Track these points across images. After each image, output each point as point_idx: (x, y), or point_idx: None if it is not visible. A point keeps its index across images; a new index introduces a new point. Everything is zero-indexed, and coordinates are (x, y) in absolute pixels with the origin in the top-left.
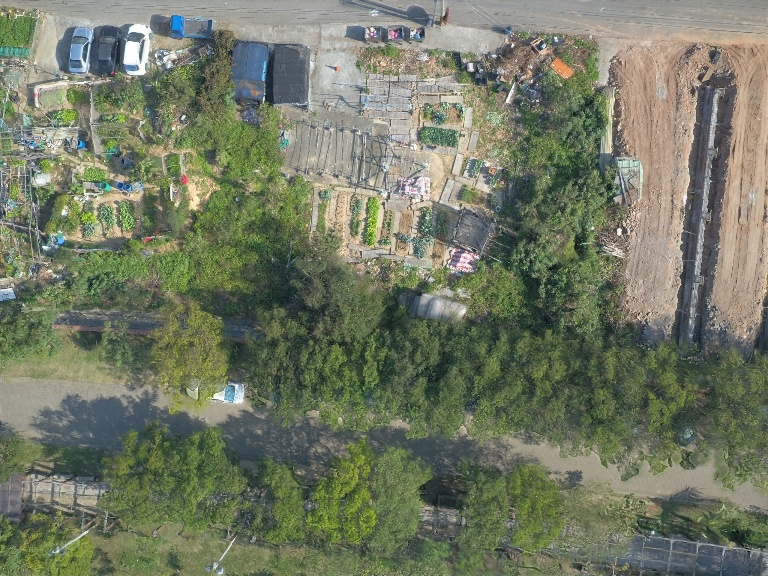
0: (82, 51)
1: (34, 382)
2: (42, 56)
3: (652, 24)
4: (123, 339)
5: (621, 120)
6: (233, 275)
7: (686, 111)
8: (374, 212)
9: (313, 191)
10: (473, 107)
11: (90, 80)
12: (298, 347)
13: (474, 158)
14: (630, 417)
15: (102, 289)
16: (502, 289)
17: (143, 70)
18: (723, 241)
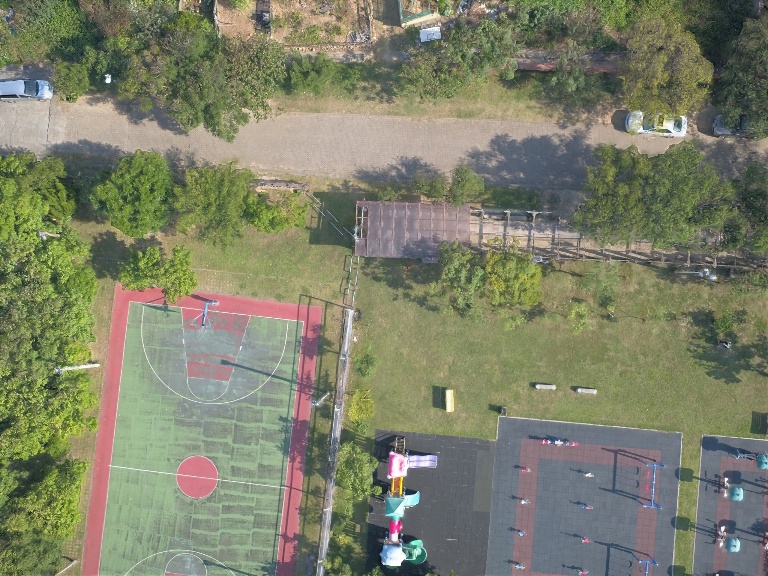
0: None
1: (461, 122)
2: None
3: None
4: None
5: None
6: (676, 6)
7: None
8: None
9: None
10: None
11: None
12: None
13: None
14: None
15: (547, 18)
16: None
17: None
18: None
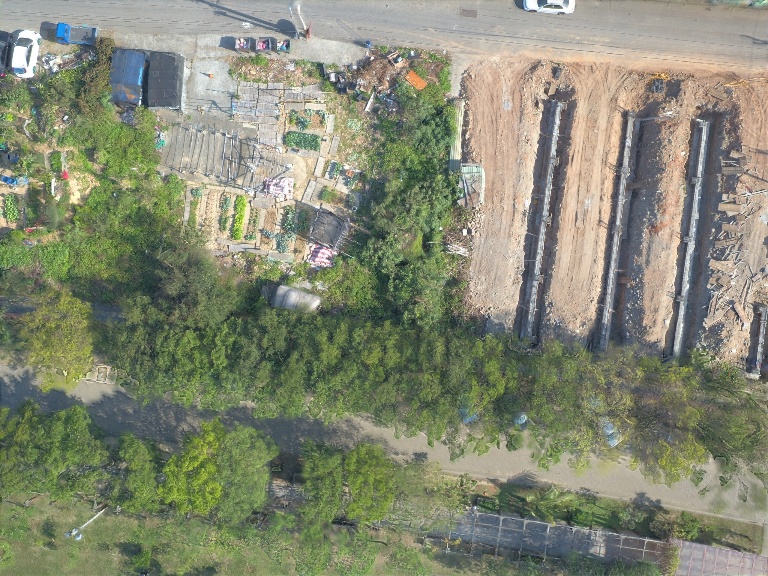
0: None
1: None
2: None
3: (501, 41)
4: (2, 322)
5: (469, 129)
6: (109, 265)
7: (529, 122)
8: (241, 209)
9: (186, 189)
10: (335, 114)
11: None
12: (155, 331)
13: (335, 161)
14: (455, 401)
15: None
16: (356, 283)
17: (31, 73)
18: (561, 243)
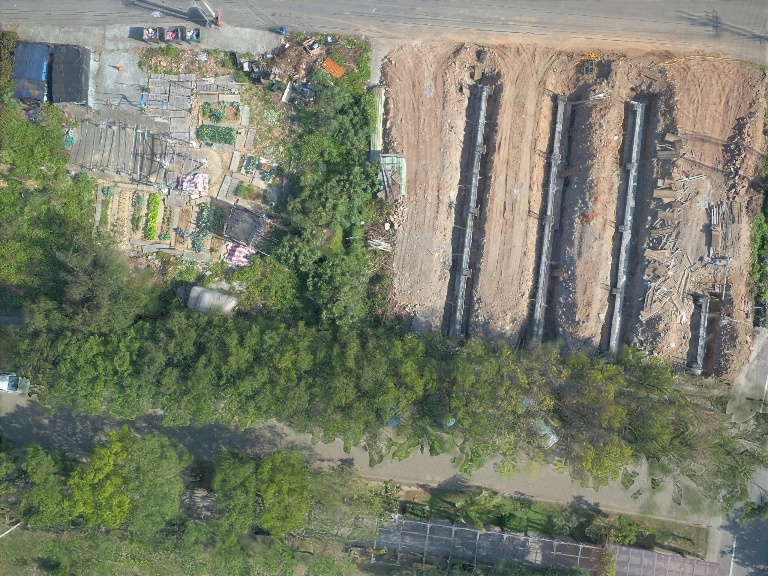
0: None
1: None
2: None
3: (422, 24)
4: None
5: (390, 118)
6: (19, 269)
7: (453, 109)
8: (154, 208)
9: (97, 187)
10: (250, 105)
11: None
12: (58, 338)
13: (251, 155)
14: (371, 405)
15: None
16: (275, 282)
17: None
18: (489, 235)
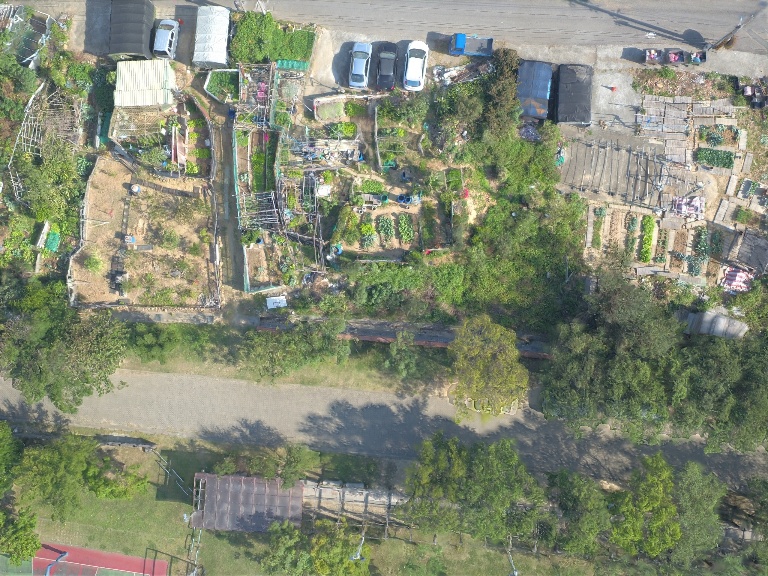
0: (365, 66)
1: (304, 389)
2: (318, 69)
3: None
4: None
5: None
6: (509, 288)
7: None
8: (649, 230)
9: (588, 208)
10: (747, 130)
11: (367, 94)
12: (602, 361)
13: (748, 179)
14: None
15: (383, 299)
16: None
17: (422, 86)
18: None
